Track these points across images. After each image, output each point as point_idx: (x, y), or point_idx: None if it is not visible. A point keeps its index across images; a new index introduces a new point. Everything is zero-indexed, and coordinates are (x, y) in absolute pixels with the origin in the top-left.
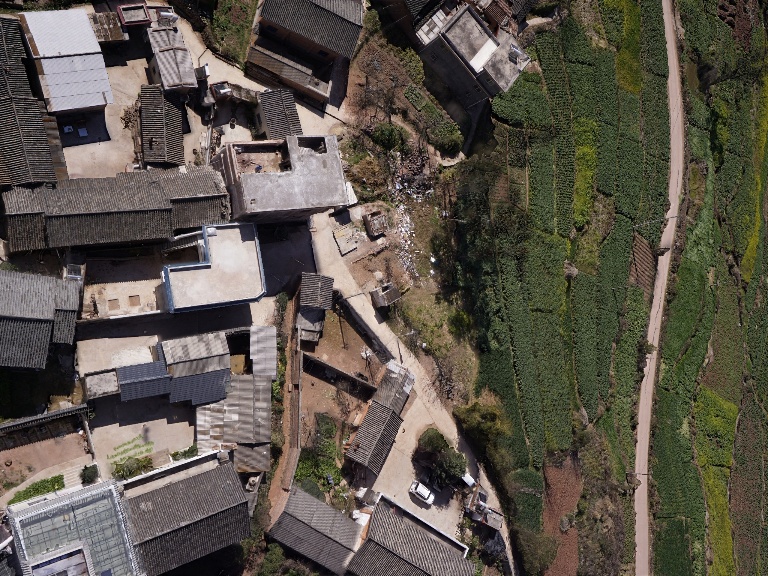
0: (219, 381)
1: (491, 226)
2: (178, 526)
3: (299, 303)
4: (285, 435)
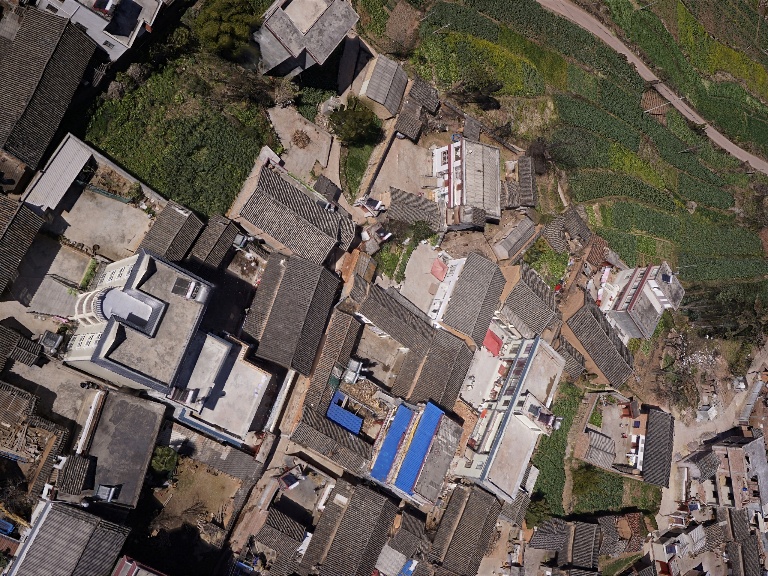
0: None
1: None
2: None
3: None
4: None
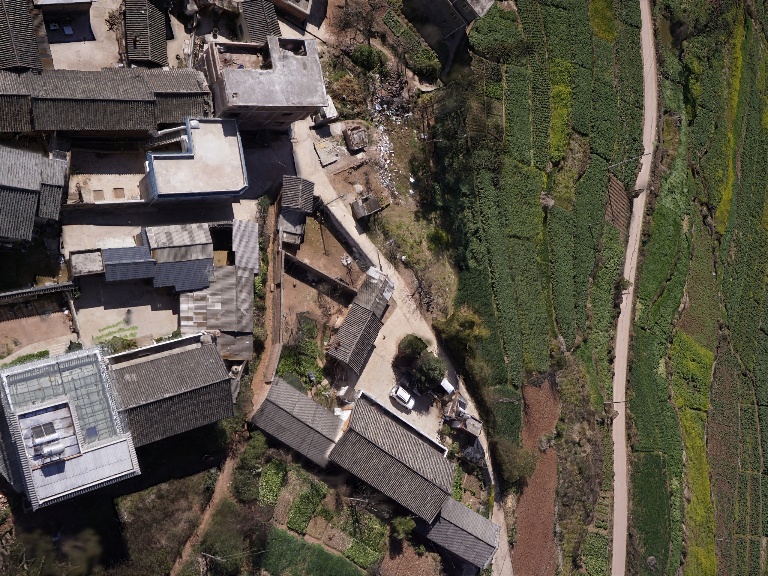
0: (202, 270)
1: (469, 150)
2: (162, 397)
3: (281, 204)
4: (267, 332)
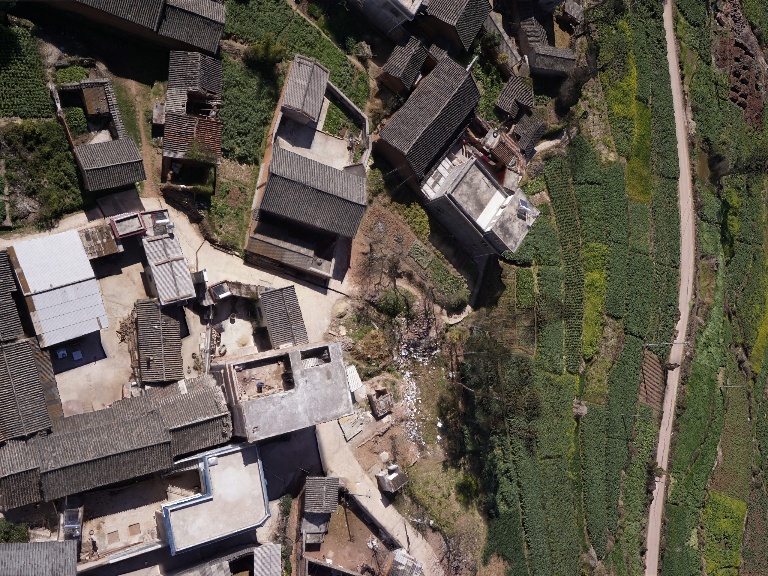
0: None
1: (499, 382)
2: None
3: (304, 509)
4: None
